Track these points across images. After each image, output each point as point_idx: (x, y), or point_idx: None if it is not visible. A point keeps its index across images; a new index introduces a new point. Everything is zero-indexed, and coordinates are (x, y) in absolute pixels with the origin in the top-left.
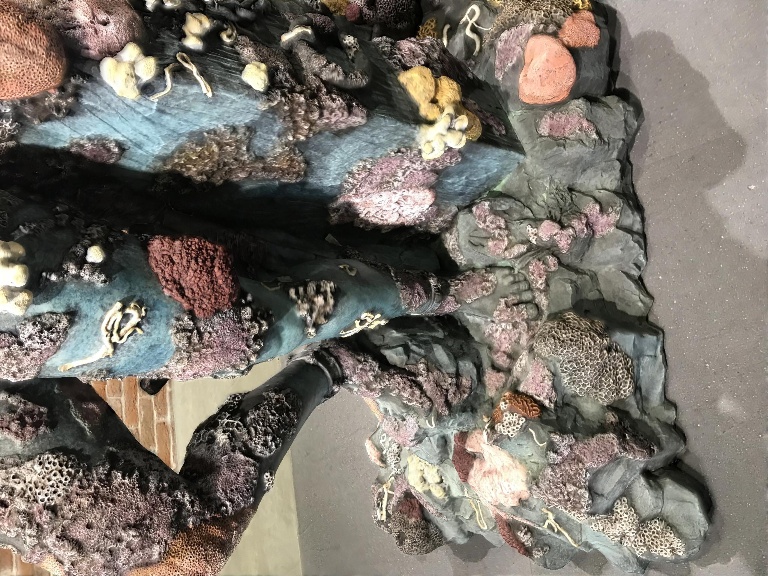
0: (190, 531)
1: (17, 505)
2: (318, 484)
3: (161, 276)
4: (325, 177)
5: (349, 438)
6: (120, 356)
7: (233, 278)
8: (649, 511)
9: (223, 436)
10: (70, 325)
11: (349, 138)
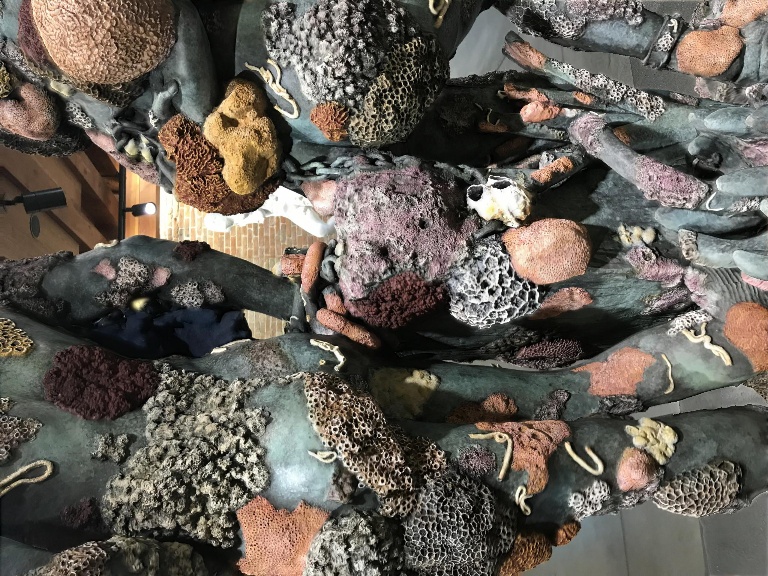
0: None
1: None
2: None
3: None
4: None
5: None
6: None
7: None
8: None
9: None
10: None
11: None
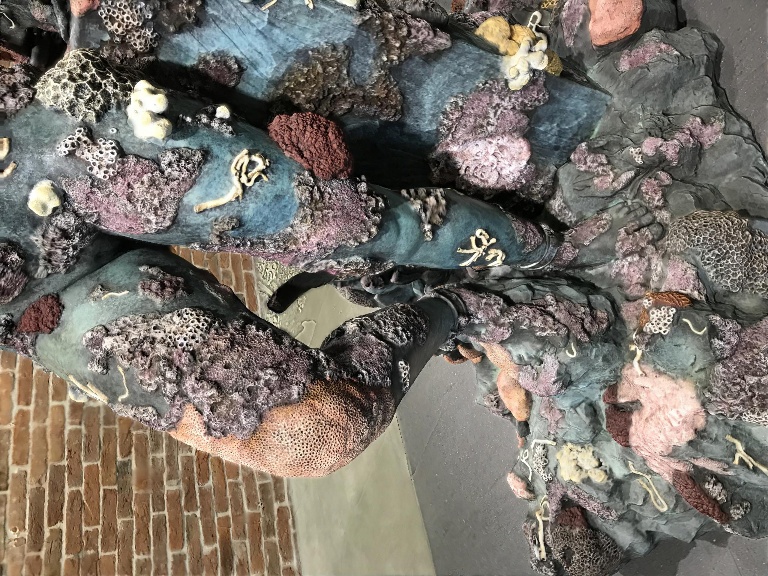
0: (328, 383)
1: (158, 352)
2: (463, 562)
3: (281, 142)
4: (421, 119)
5: (489, 493)
6: (249, 202)
7: (346, 146)
8: None
9: (352, 325)
10: (204, 161)
11: (438, 66)
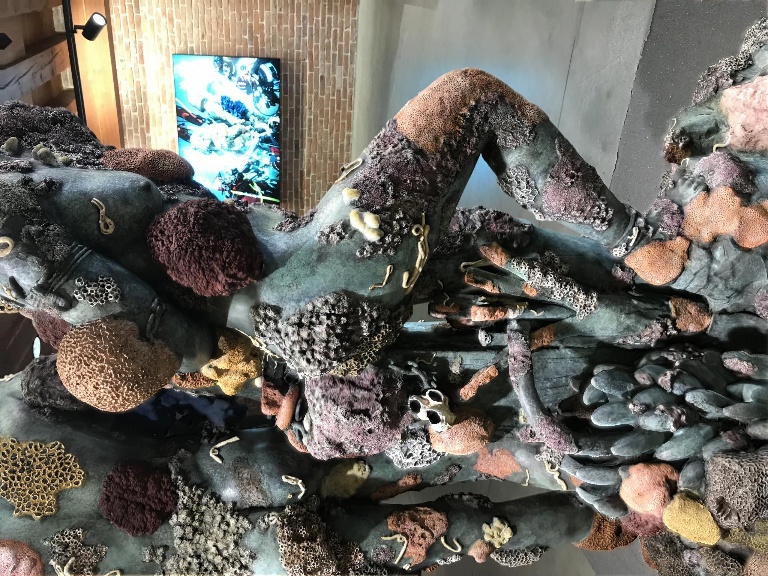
0: None
1: None
2: None
3: None
4: None
5: None
6: None
7: None
8: None
9: None
10: None
11: None
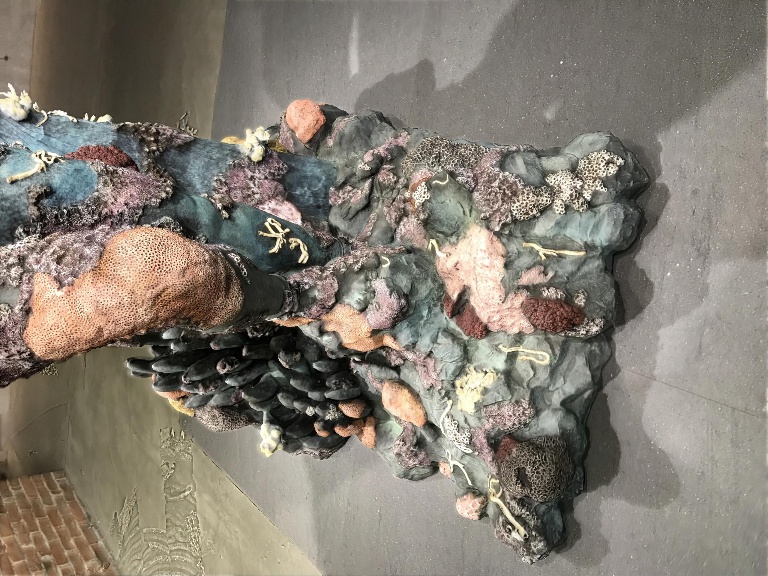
0: None
1: None
2: None
3: None
4: None
5: (465, 569)
6: (53, 173)
7: None
8: (568, 162)
9: None
10: (7, 153)
11: (192, 155)
